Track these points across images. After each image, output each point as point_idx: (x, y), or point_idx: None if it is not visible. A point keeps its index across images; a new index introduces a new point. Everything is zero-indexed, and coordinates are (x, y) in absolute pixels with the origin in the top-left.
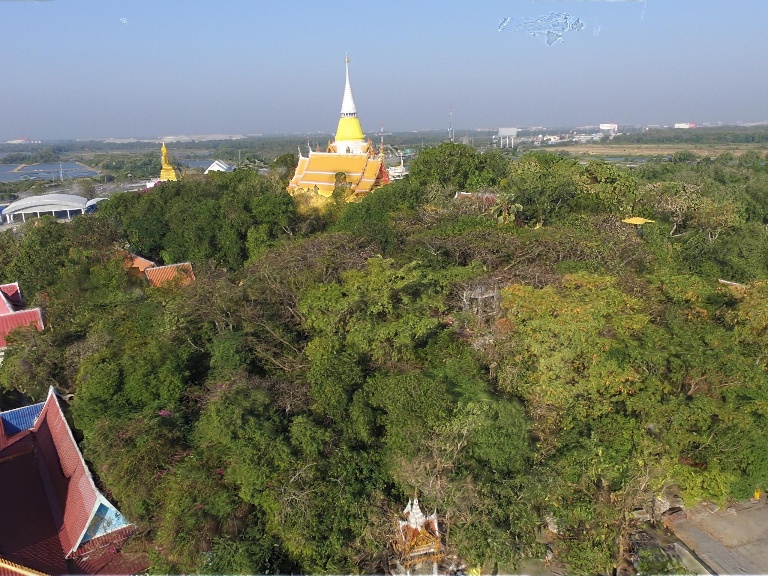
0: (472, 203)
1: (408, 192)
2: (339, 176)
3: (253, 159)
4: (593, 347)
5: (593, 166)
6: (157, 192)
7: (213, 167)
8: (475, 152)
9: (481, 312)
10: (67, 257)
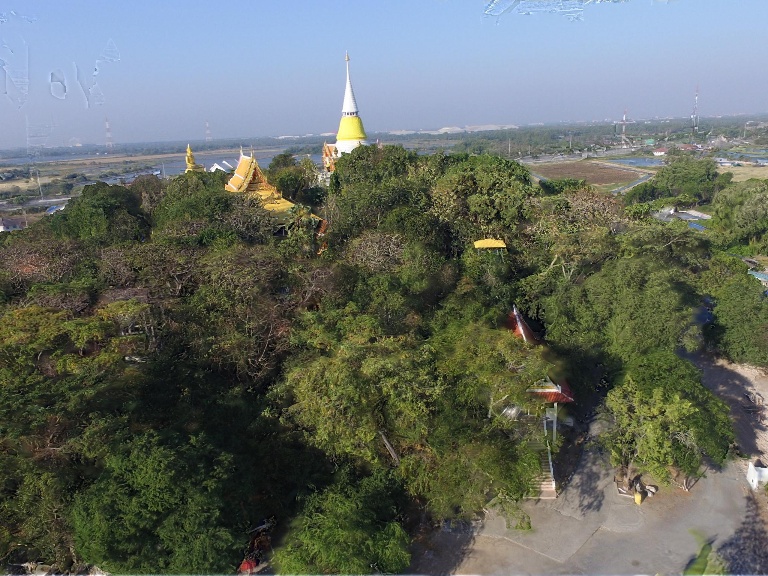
0: (267, 214)
1: (212, 200)
2: (177, 181)
3: (477, 151)
4: (2, 380)
5: (479, 174)
6: (83, 191)
7: (215, 167)
8: (406, 154)
9: (152, 329)
10: (3, 242)
